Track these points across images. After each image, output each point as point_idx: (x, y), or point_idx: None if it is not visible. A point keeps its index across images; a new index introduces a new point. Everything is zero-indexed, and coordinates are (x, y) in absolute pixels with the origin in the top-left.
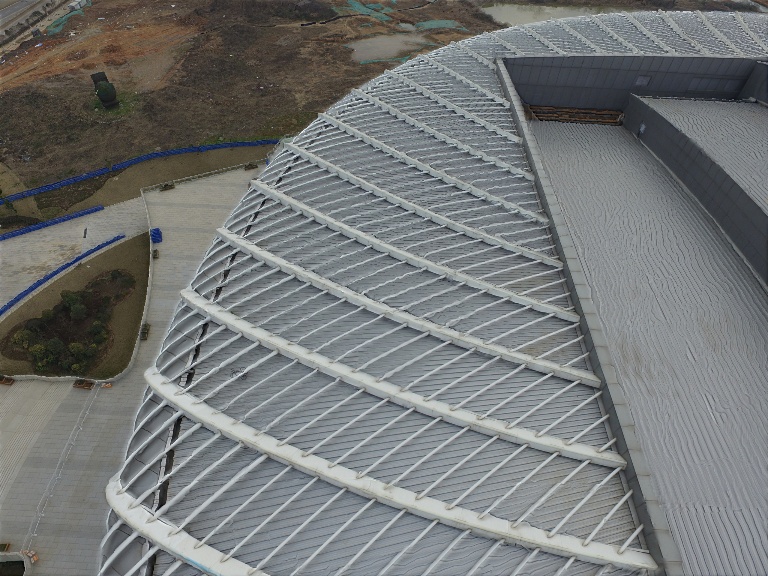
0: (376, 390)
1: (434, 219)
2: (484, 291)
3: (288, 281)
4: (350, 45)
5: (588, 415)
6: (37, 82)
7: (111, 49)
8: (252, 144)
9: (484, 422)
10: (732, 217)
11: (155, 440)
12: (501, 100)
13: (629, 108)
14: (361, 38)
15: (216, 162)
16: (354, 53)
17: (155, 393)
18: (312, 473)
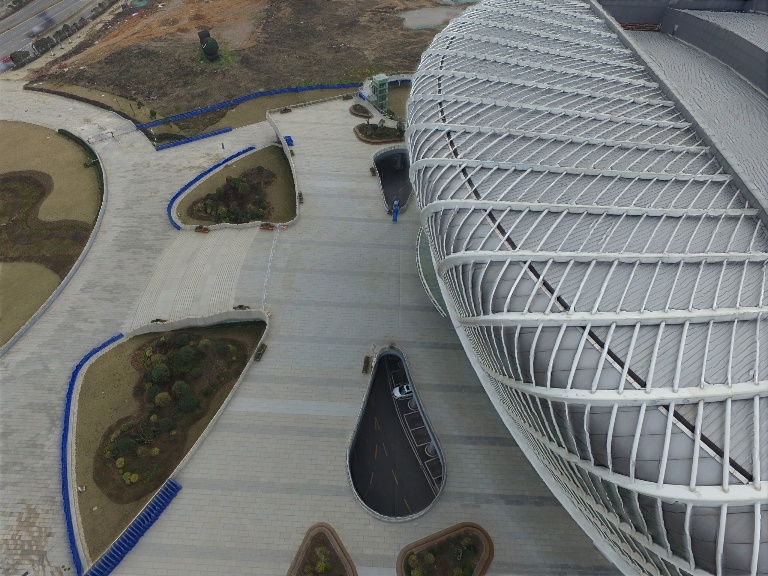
0: (557, 110)
1: (561, 54)
2: (602, 78)
3: (484, 81)
4: (400, 15)
5: (669, 115)
6: (144, 42)
7: (198, 17)
8: (338, 87)
9: None
10: (740, 59)
11: (438, 141)
12: (583, 4)
13: (665, 18)
14: (409, 10)
15: (311, 99)
16: (405, 21)
17: (426, 128)
18: (537, 134)
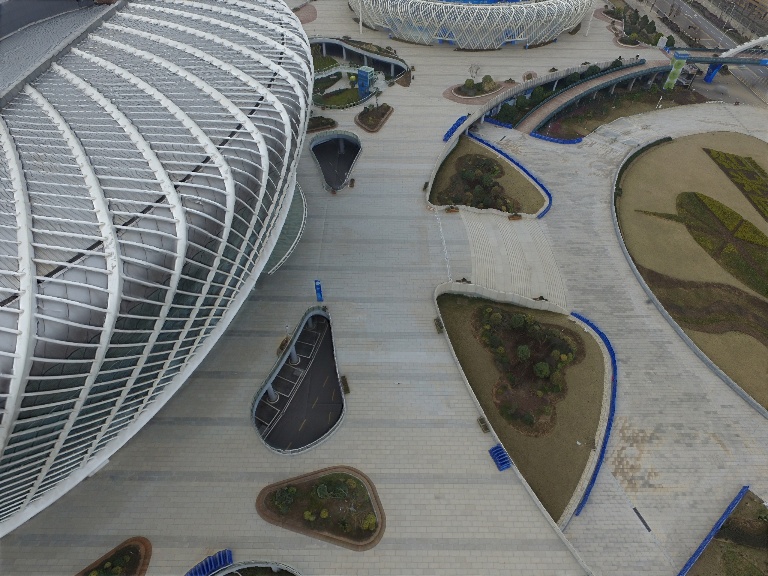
0: None
1: None
2: None
3: None
4: None
5: None
6: None
7: None
8: None
9: (158, 22)
10: None
11: None
12: None
13: None
14: None
15: None
16: None
17: None
18: None
